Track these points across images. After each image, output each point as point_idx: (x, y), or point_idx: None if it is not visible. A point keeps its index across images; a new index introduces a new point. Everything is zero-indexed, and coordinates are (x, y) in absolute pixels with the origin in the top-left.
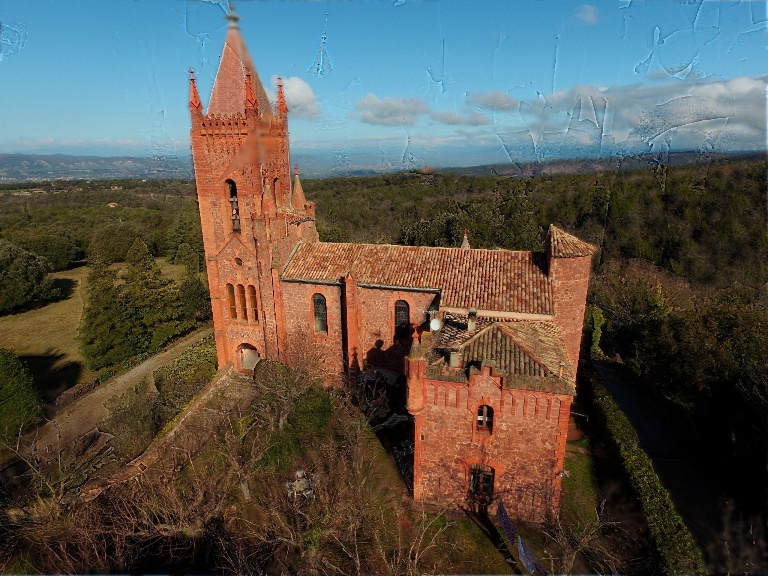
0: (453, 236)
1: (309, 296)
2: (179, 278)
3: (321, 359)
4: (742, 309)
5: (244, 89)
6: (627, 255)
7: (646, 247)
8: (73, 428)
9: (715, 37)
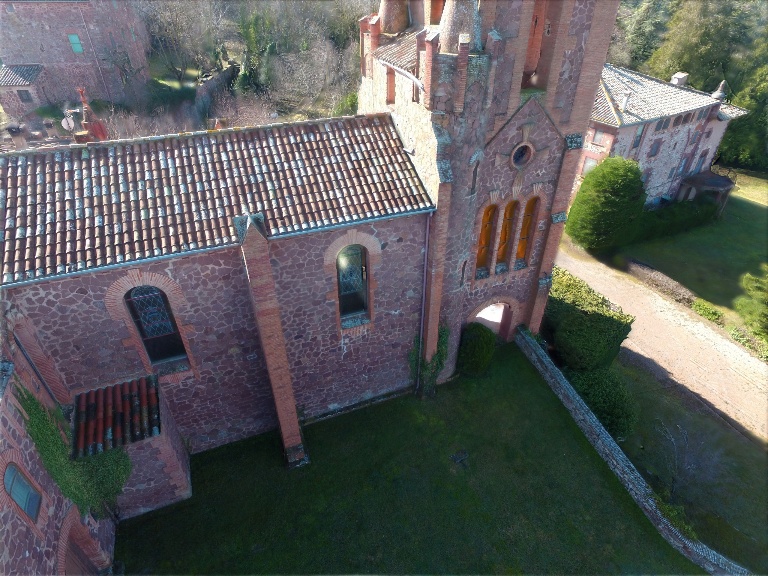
0: None
1: None
2: None
3: None
4: None
5: None
6: None
7: None
8: (570, 268)
9: None
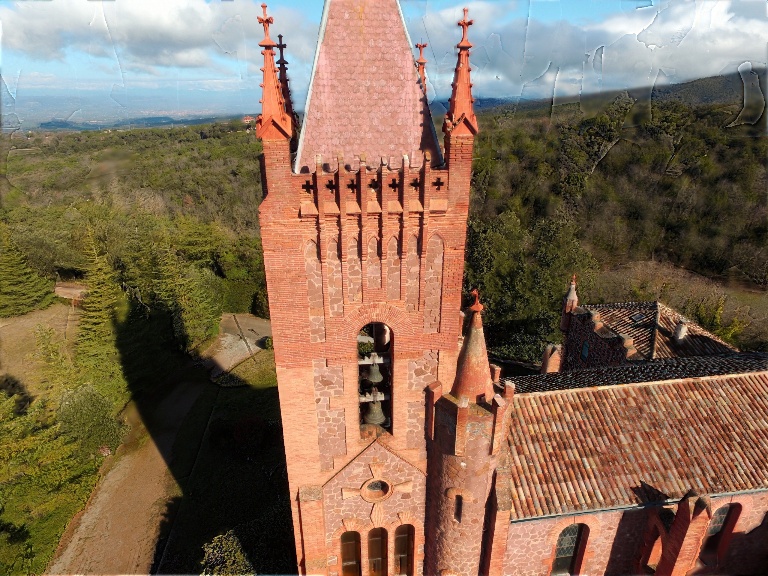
0: (476, 258)
1: (556, 532)
2: (39, 387)
3: None
4: None
5: (412, 81)
6: (600, 243)
7: (624, 236)
8: None
9: (714, 5)
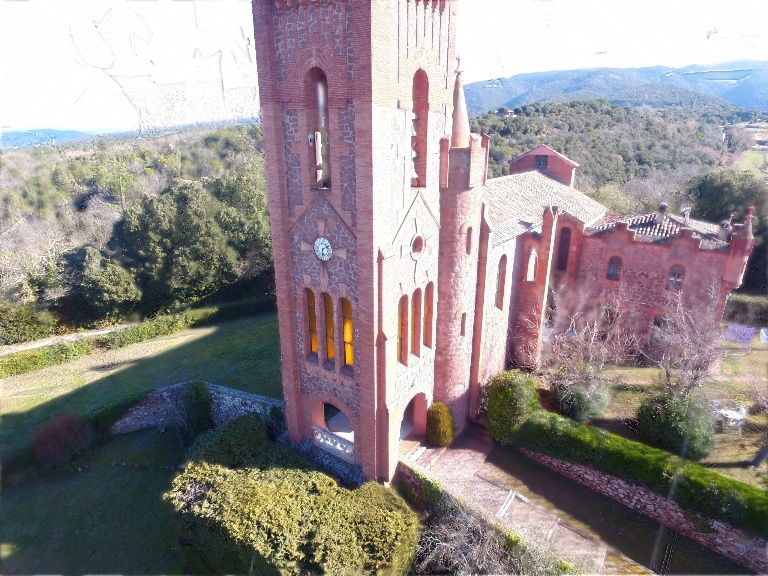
0: (243, 202)
1: (498, 263)
2: None
3: (494, 347)
4: None
5: None
6: None
7: None
8: None
9: None
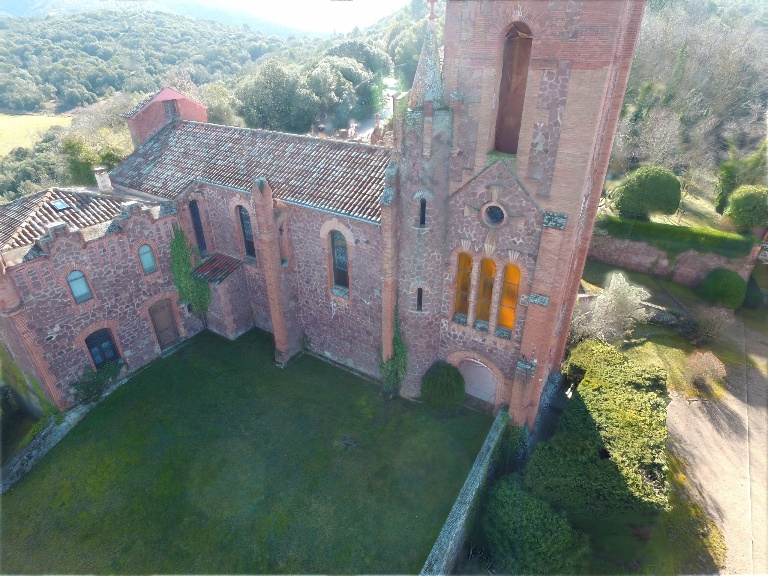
0: None
1: None
2: None
3: None
4: (117, 137)
5: None
6: None
7: None
8: None
9: None
